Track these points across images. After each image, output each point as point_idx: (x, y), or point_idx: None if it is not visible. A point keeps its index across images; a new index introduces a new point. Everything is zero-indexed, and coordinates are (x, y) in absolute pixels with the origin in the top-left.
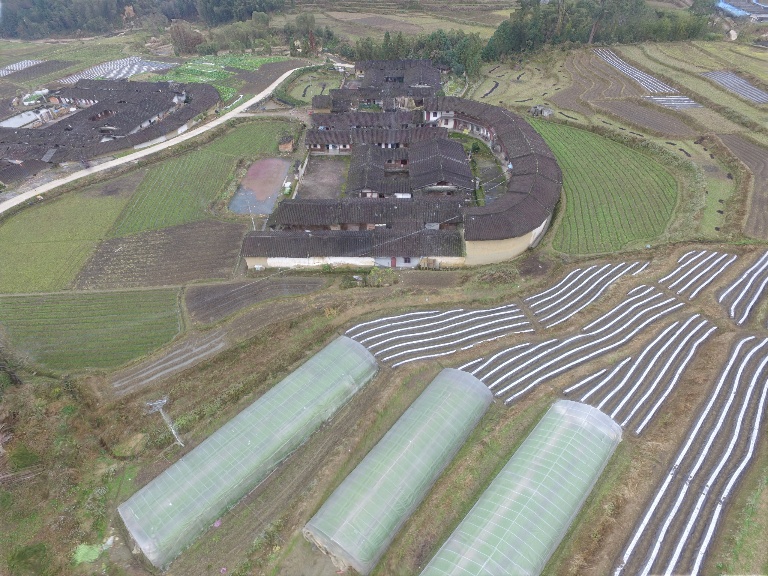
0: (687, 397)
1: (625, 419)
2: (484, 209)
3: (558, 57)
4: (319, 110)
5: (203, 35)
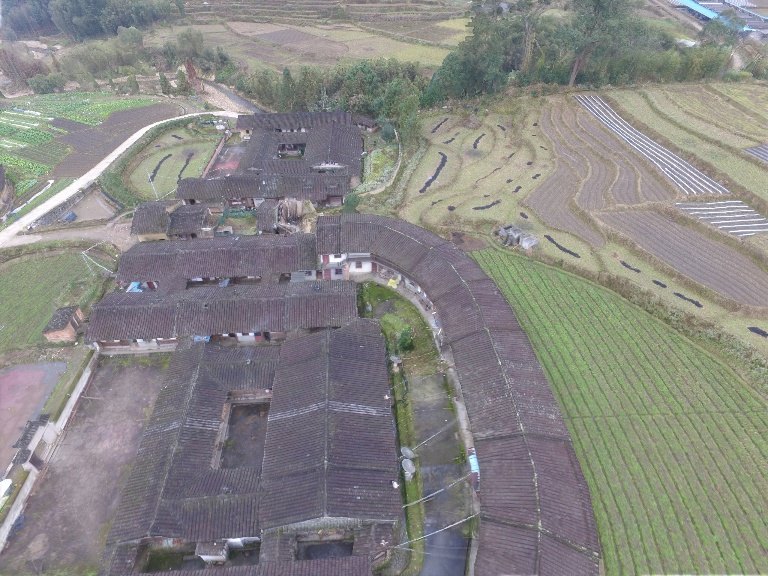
0: None
1: None
2: None
3: (529, 107)
4: (146, 235)
5: (62, 54)
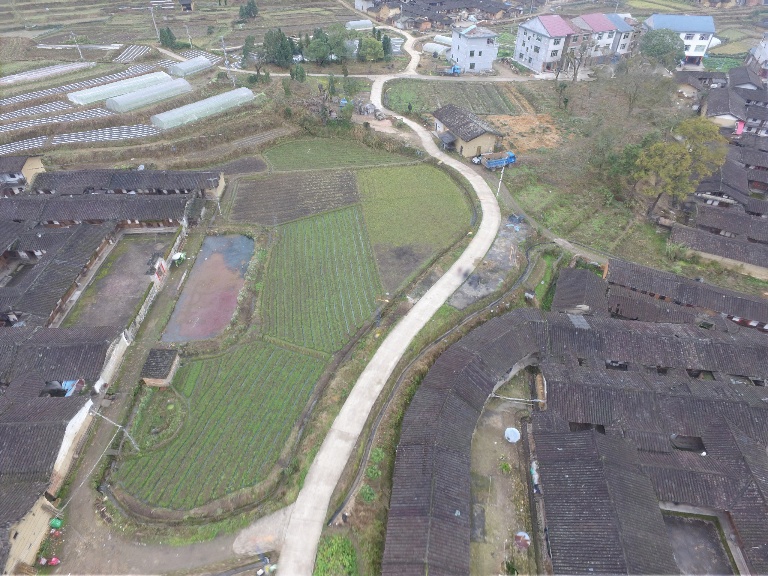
0: (26, 103)
1: (60, 103)
2: (1, 165)
3: None
4: None
5: None
